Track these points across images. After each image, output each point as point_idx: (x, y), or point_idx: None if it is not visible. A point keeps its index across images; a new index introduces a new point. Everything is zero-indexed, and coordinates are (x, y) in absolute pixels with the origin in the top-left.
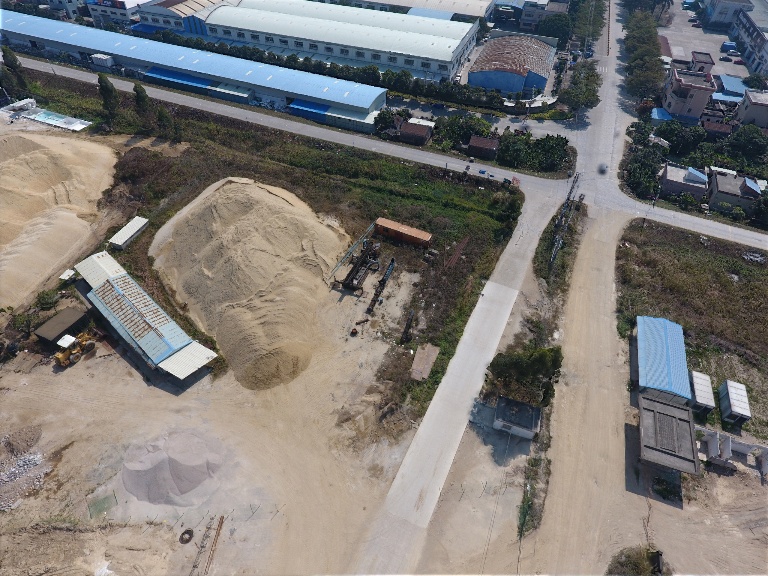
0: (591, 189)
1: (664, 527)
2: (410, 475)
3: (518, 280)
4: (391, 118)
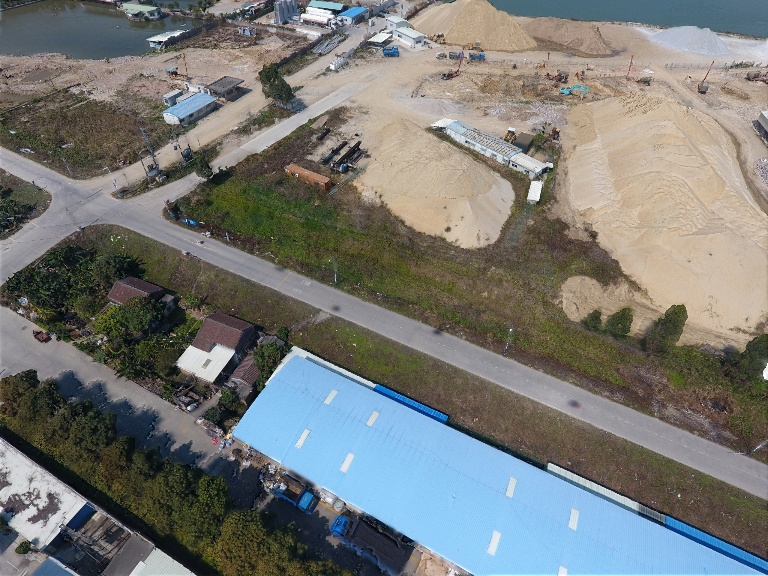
0: (81, 210)
1: (248, 83)
2: (339, 99)
3: (235, 152)
4: (260, 345)
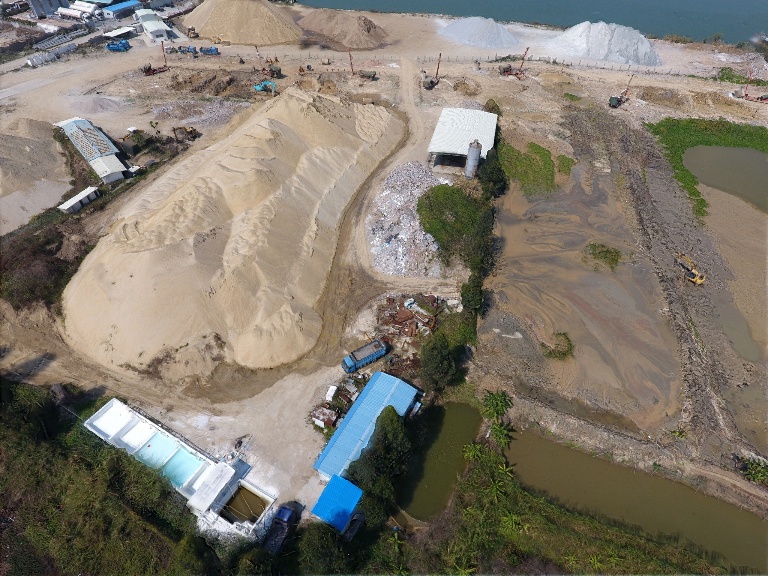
0: None
1: None
2: None
3: None
4: None
